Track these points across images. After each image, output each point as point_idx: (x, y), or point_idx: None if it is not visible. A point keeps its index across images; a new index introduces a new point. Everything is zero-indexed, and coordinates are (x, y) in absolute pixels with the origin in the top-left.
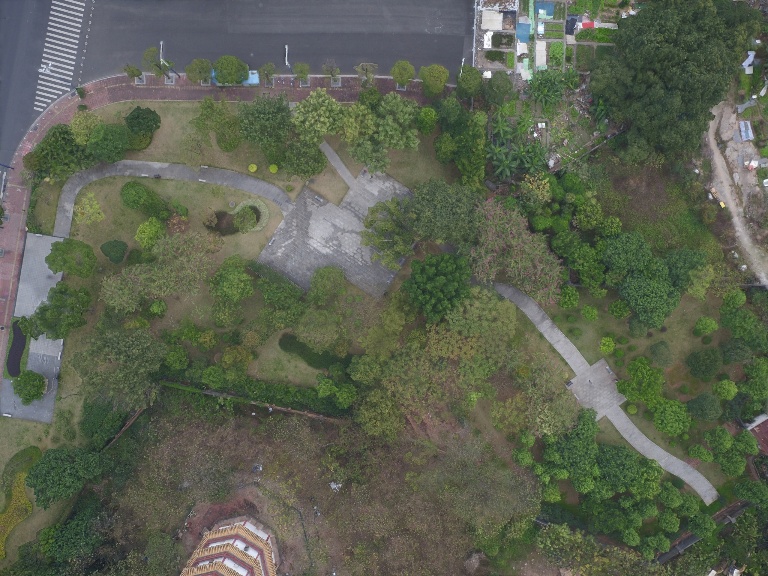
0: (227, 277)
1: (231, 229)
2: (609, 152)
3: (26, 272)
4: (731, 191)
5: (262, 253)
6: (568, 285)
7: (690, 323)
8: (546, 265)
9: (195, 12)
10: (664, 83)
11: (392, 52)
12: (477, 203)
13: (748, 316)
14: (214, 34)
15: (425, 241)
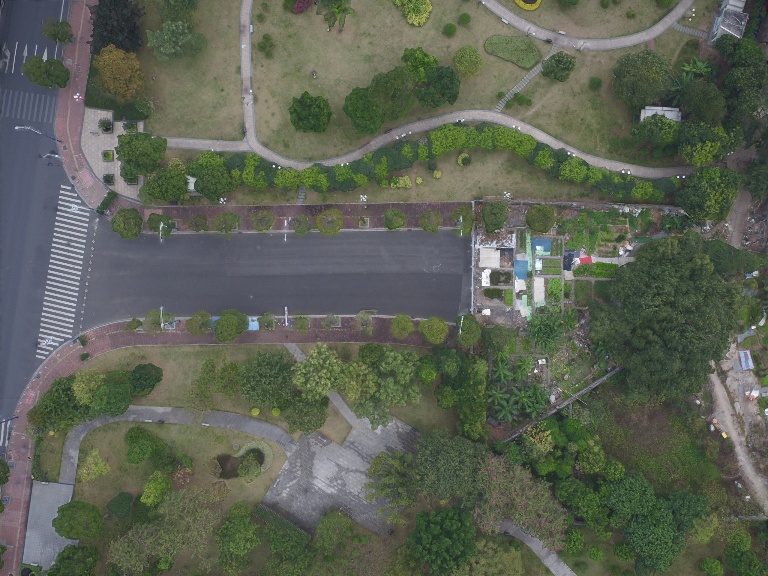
0: (233, 532)
1: (236, 472)
2: (610, 386)
3: (33, 519)
4: (733, 420)
5: (267, 494)
6: (573, 530)
7: (695, 556)
8: (550, 513)
9: (194, 256)
10: (663, 341)
11: (391, 292)
12: (480, 461)
13: (753, 564)
14: (213, 277)
15: (429, 496)
